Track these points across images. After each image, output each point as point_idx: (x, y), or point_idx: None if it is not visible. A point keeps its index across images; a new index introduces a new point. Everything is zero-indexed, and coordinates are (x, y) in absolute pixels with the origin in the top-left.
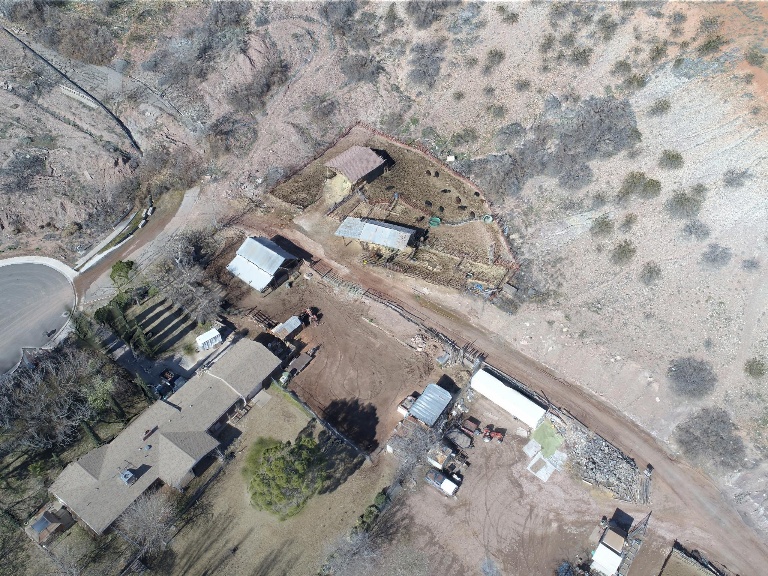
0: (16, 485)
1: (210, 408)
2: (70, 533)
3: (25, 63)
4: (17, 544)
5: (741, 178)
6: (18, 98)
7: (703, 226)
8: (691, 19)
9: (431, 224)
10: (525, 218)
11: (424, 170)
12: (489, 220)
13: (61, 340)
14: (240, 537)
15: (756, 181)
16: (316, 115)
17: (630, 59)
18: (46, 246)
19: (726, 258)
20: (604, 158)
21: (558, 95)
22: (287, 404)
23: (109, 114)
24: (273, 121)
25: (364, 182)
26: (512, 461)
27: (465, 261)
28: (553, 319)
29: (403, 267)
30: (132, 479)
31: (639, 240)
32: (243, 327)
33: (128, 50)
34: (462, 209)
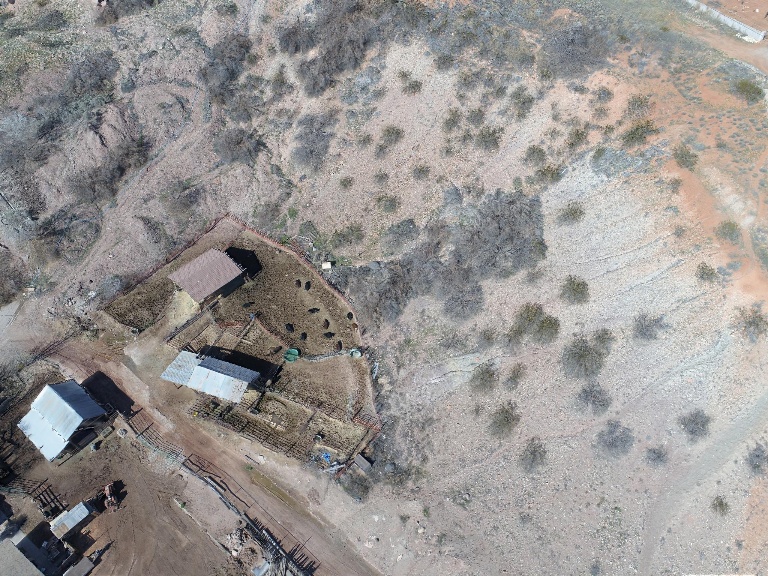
0: None
1: None
2: None
3: None
4: None
5: (654, 327)
6: None
7: (603, 393)
8: (618, 97)
9: (286, 359)
10: (399, 355)
11: (294, 279)
12: (358, 354)
13: None
14: None
15: (672, 334)
16: (174, 206)
17: (545, 144)
18: None
19: (627, 444)
20: (500, 278)
21: (460, 186)
22: None
23: None
24: (122, 214)
25: (219, 296)
26: None
27: (318, 415)
28: (408, 513)
29: (240, 422)
30: None
31: (525, 404)
32: (21, 512)
33: None
34: (328, 337)
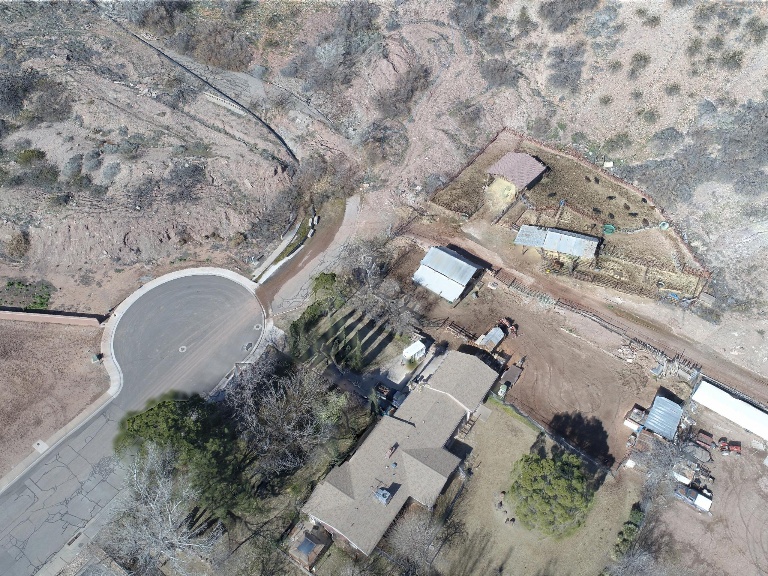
0: (261, 505)
1: (442, 423)
2: (330, 554)
3: (164, 70)
4: (277, 566)
5: None
6: (164, 106)
7: None
8: None
9: (606, 232)
10: (704, 225)
11: (582, 176)
12: (664, 227)
13: (261, 354)
14: (502, 556)
15: None
16: (464, 121)
17: None
18: (216, 257)
19: None
20: None
21: (712, 99)
22: (510, 418)
23: (259, 121)
24: (422, 127)
25: (525, 189)
26: (756, 475)
27: (651, 269)
28: (762, 329)
29: (588, 276)
30: (389, 498)
31: None
32: (441, 339)
33: (264, 56)
34: (633, 216)
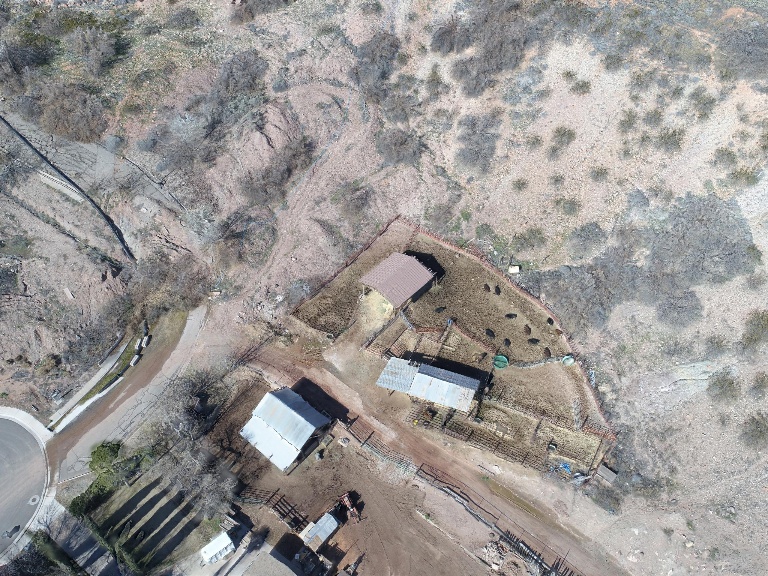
0: None
1: None
2: None
3: None
4: None
5: None
6: None
7: None
8: None
9: (496, 366)
10: (616, 362)
11: (481, 284)
12: (569, 361)
13: (26, 544)
14: None
15: None
16: (347, 209)
17: (735, 147)
18: (15, 390)
19: None
20: (715, 284)
21: (644, 189)
22: None
23: (97, 210)
24: (295, 217)
25: (408, 301)
26: None
27: (544, 424)
28: (671, 526)
29: (464, 431)
30: None
31: None
32: (262, 523)
33: (122, 123)
34: (533, 344)
